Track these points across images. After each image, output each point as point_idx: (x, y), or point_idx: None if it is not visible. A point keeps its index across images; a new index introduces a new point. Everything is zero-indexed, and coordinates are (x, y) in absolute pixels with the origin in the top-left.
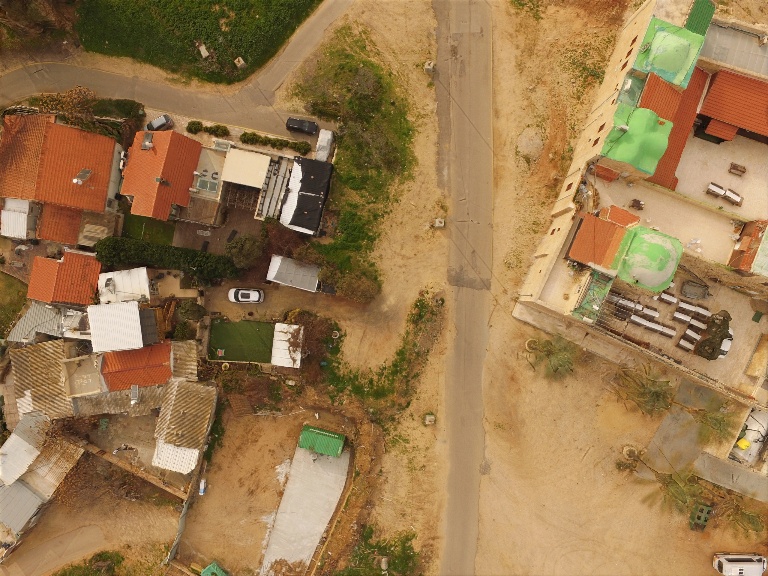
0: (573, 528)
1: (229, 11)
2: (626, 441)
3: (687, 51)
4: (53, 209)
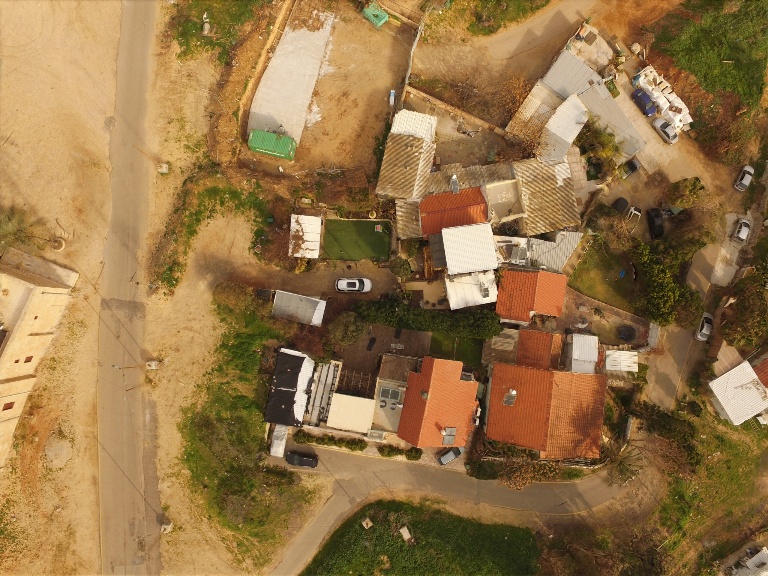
0: (23, 67)
1: None
2: None
3: None
4: (541, 364)
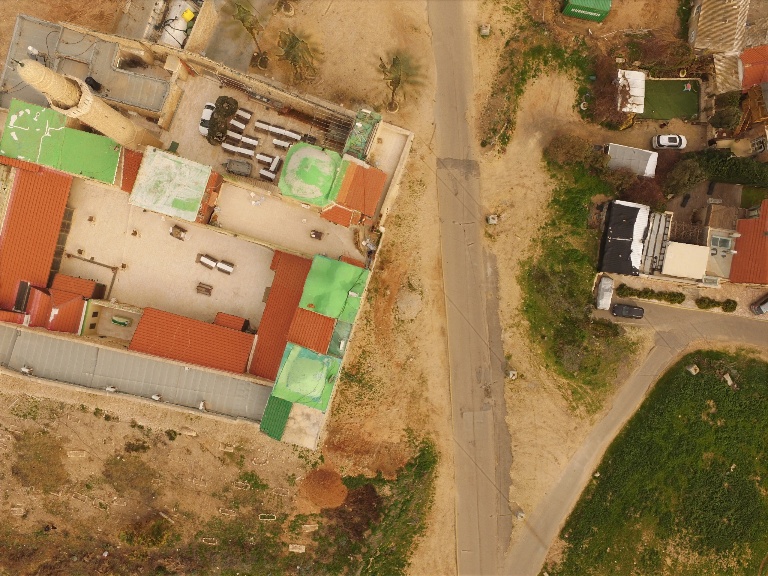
0: None
1: (708, 420)
2: (292, 21)
3: (290, 379)
4: None
